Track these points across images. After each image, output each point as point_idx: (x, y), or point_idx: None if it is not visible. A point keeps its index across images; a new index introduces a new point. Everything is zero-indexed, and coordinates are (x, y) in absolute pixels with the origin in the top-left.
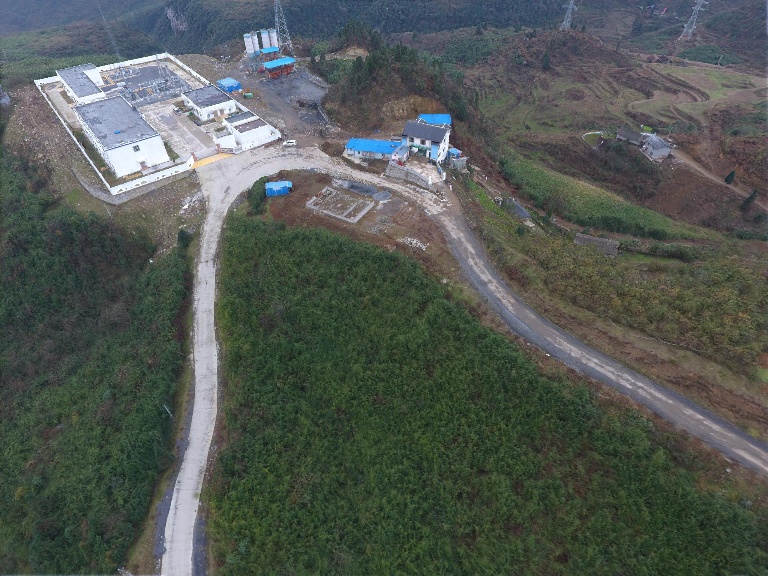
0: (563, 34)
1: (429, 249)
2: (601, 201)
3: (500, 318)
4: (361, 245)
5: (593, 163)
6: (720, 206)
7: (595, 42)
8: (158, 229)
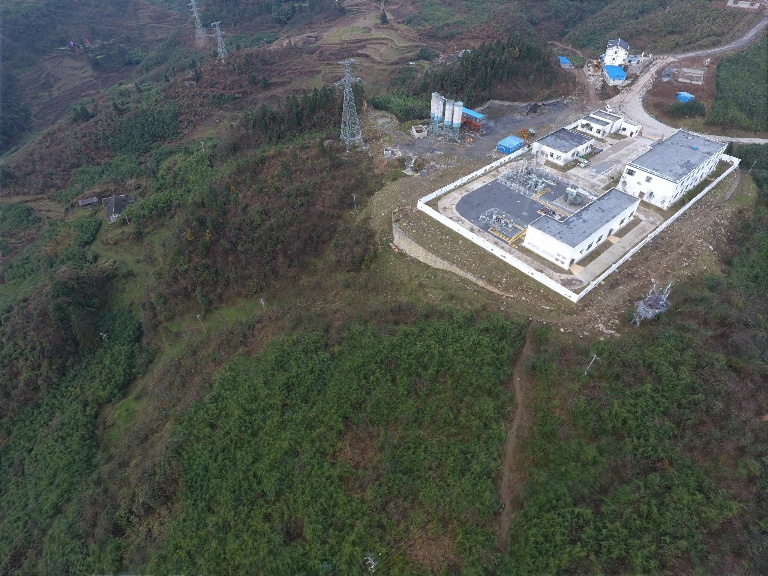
0: None
1: None
2: None
3: (740, 47)
4: None
5: None
6: None
7: (268, 50)
8: None
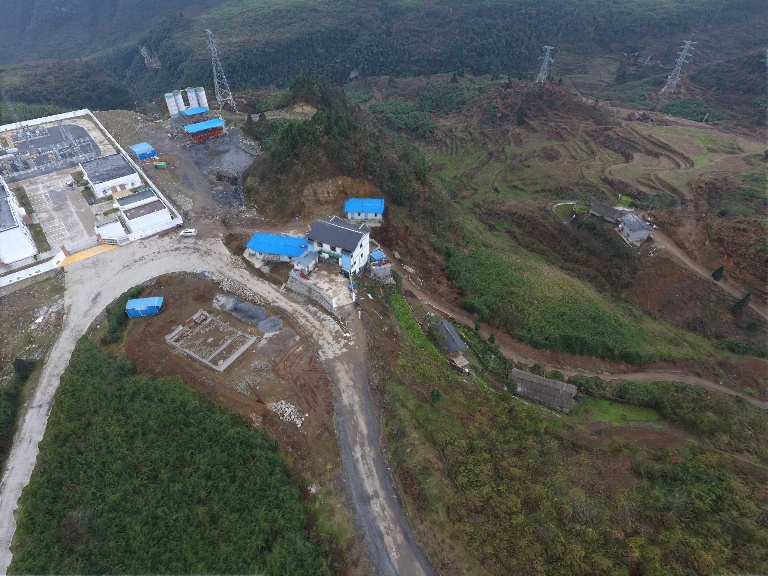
0: (539, 87)
1: (306, 424)
2: (562, 310)
3: None
4: (218, 412)
5: (563, 241)
6: (707, 306)
7: (572, 96)
8: None
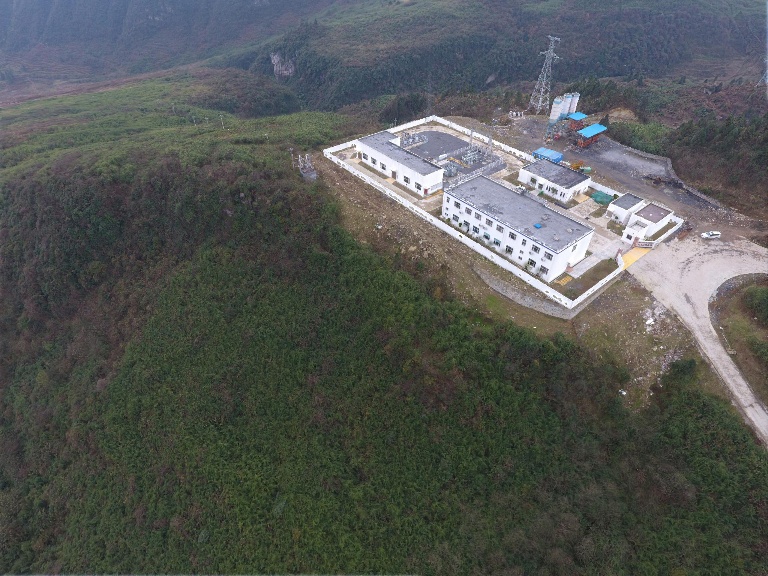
0: (765, 89)
1: None
2: None
3: None
4: None
5: None
6: None
7: None
8: (624, 351)
